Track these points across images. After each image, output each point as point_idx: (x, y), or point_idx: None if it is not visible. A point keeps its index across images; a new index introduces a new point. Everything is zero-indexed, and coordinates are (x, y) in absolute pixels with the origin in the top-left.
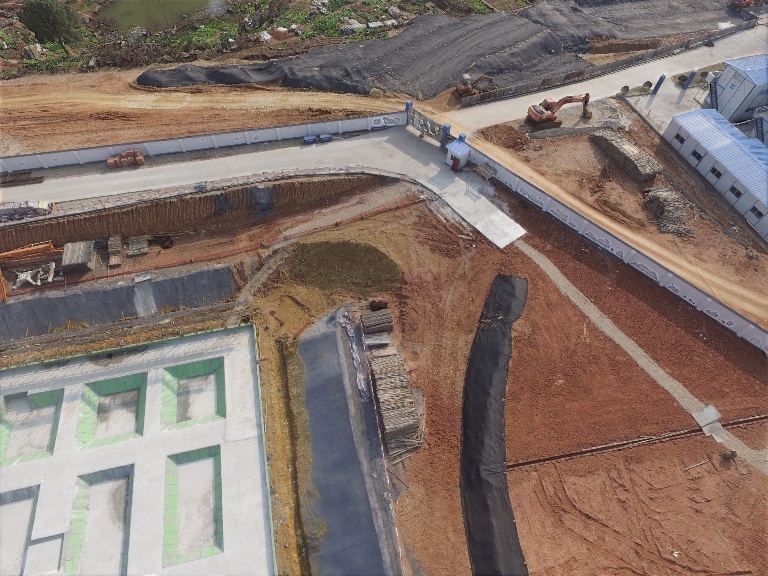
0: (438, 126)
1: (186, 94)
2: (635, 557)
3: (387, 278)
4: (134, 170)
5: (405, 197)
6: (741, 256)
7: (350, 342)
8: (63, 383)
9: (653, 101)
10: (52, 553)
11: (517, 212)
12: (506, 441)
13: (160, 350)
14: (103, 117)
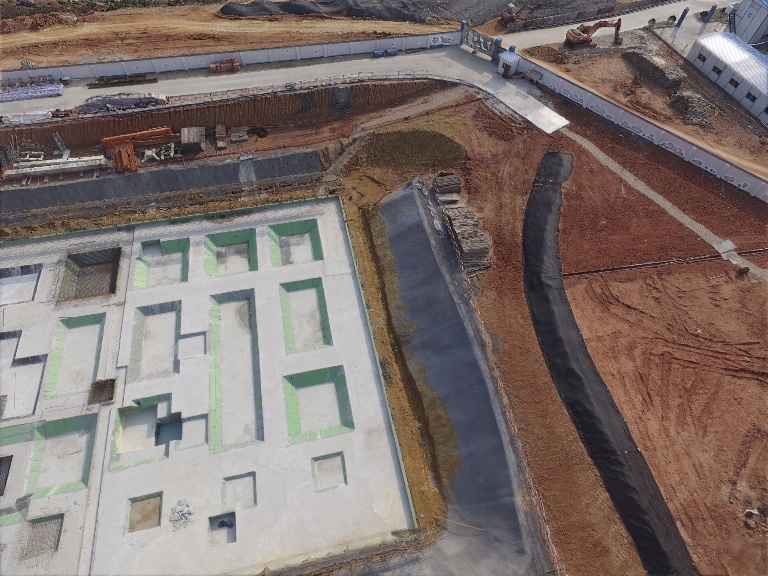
0: (490, 40)
1: (264, 21)
2: (667, 332)
3: (452, 157)
4: (232, 74)
5: (464, 97)
6: (755, 142)
7: (426, 199)
8: (188, 234)
9: (677, 32)
10: (198, 344)
11: (561, 108)
12: (561, 259)
13: (263, 213)
14: (196, 38)
